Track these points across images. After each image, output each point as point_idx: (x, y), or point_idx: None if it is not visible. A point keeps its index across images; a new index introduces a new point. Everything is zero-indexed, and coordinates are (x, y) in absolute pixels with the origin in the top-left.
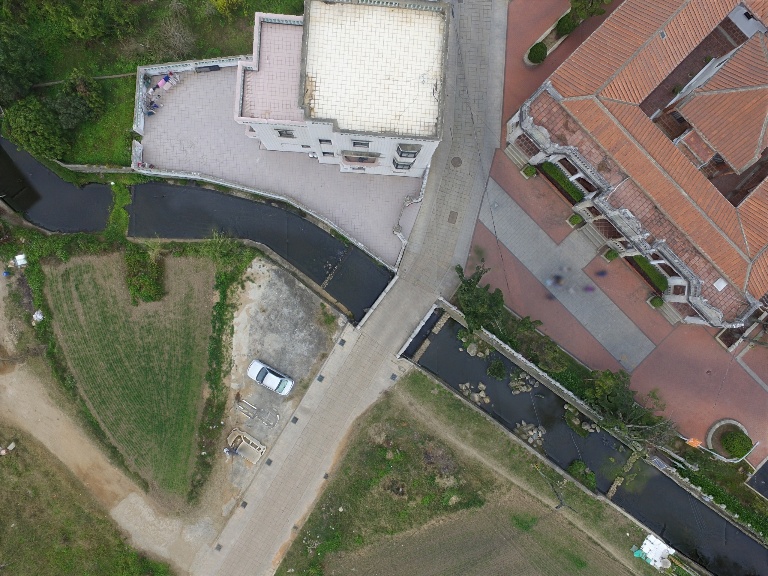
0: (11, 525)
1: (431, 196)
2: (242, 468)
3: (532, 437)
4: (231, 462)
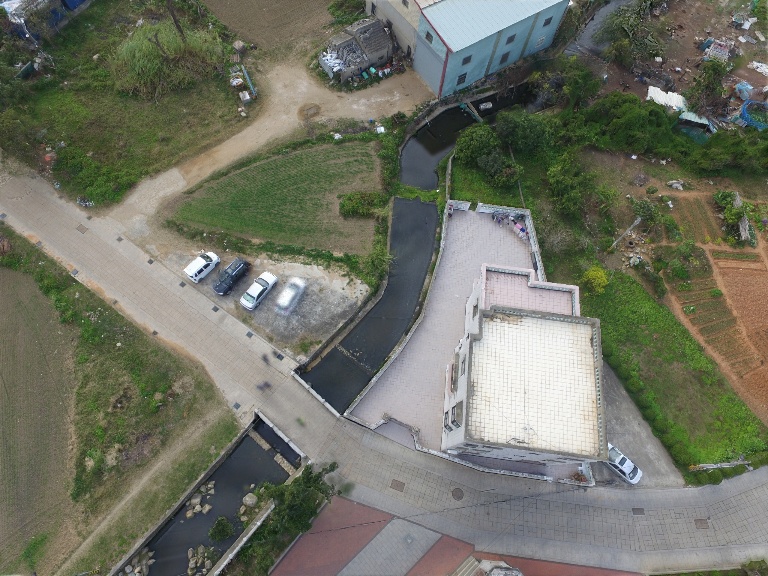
0: (185, 110)
1: (421, 461)
2: (184, 263)
3: (132, 571)
4: (191, 255)
